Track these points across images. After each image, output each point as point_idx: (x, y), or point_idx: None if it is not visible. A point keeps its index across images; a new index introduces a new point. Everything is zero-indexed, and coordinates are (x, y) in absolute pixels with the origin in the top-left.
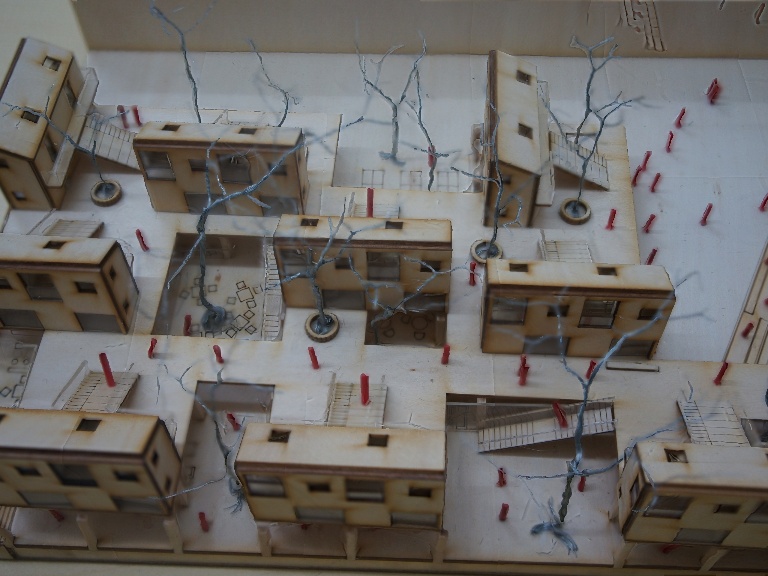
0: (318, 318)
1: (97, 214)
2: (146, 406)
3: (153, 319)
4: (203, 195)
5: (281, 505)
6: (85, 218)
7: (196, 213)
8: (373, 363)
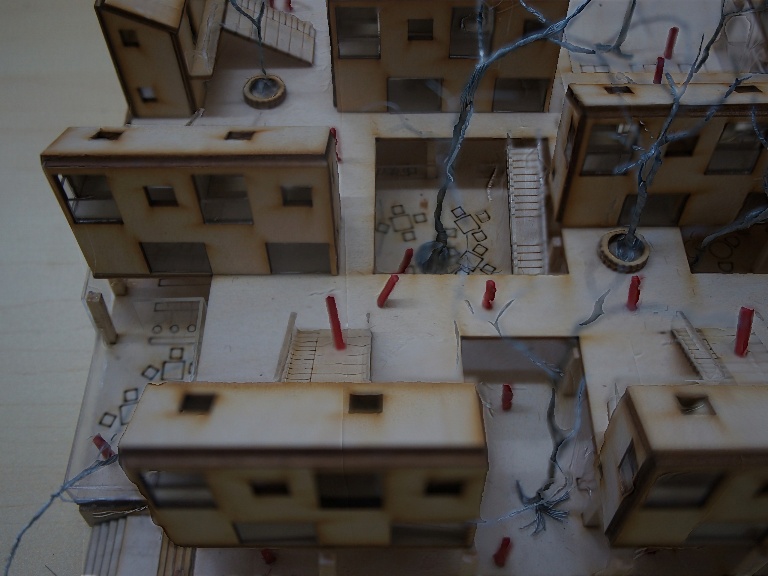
0: (617, 239)
1: (256, 119)
2: (392, 377)
3: (371, 253)
4: (414, 81)
5: (682, 521)
6: (241, 124)
7: (397, 112)
8: (714, 298)
